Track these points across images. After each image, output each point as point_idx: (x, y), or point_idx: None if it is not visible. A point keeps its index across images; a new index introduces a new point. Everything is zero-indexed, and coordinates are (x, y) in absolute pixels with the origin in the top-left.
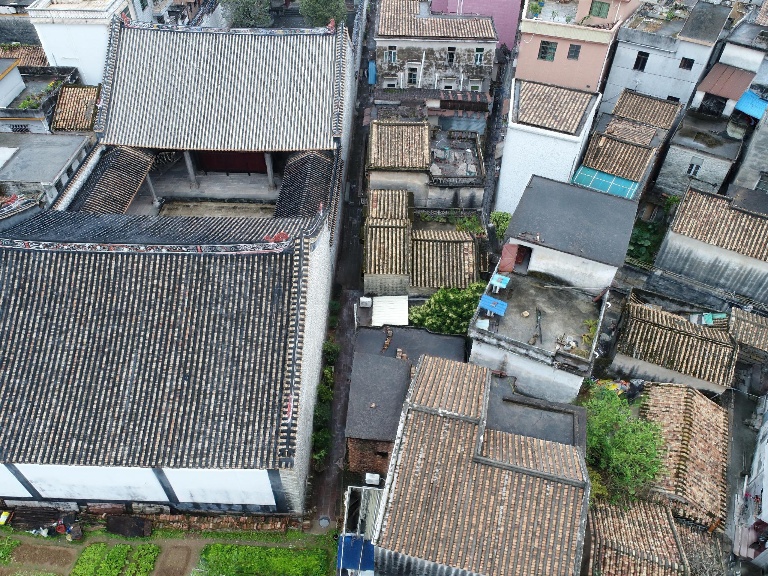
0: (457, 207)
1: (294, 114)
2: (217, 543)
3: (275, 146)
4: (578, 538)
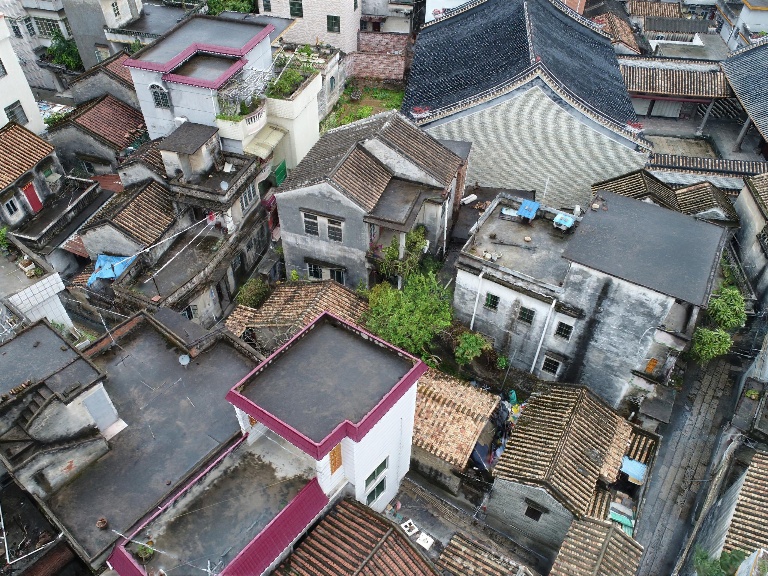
0: (757, 285)
1: None
2: None
3: None
4: None
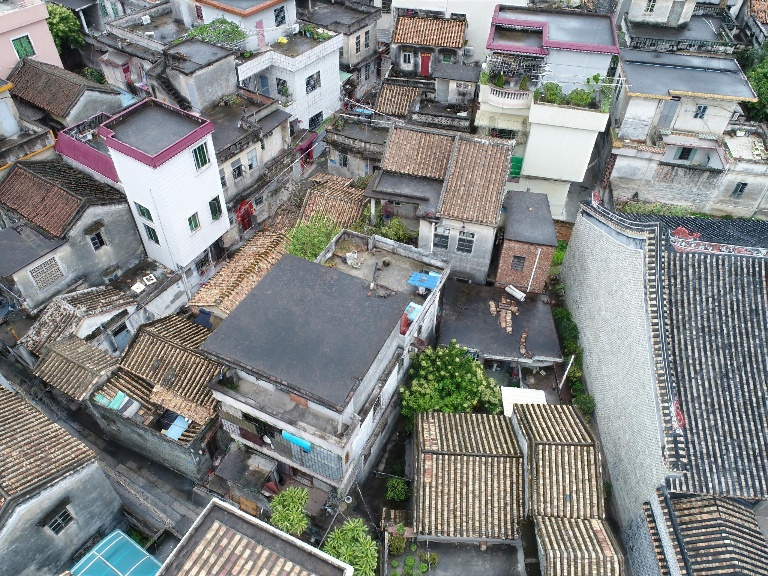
0: None
1: None
2: None
3: None
4: None
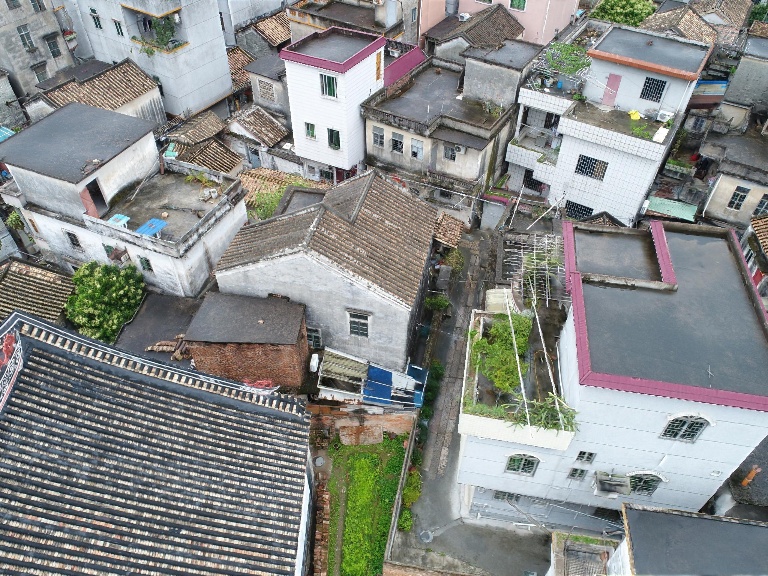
0: None
1: None
2: (342, 567)
3: None
4: (407, 190)
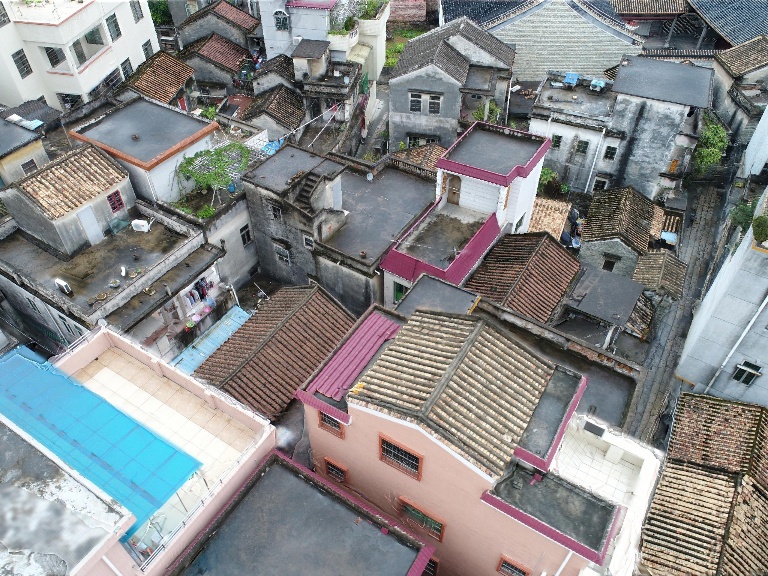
0: None
1: (767, 26)
2: None
3: (729, 36)
4: None
